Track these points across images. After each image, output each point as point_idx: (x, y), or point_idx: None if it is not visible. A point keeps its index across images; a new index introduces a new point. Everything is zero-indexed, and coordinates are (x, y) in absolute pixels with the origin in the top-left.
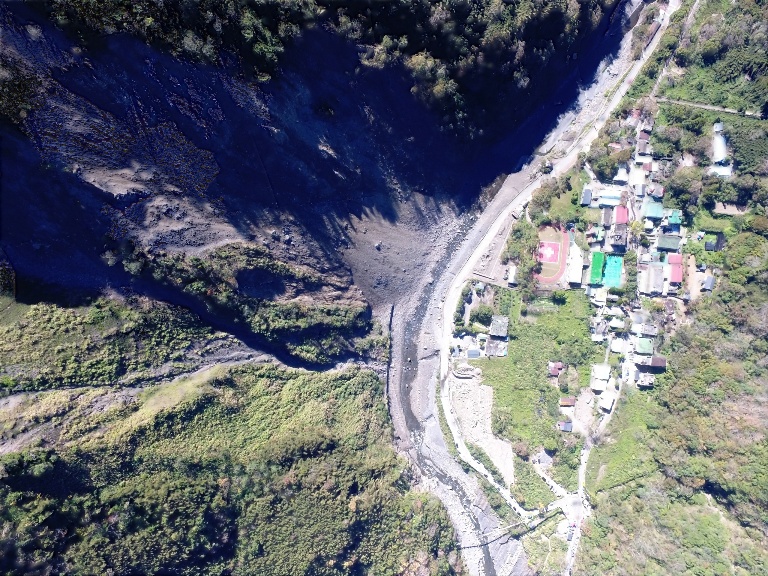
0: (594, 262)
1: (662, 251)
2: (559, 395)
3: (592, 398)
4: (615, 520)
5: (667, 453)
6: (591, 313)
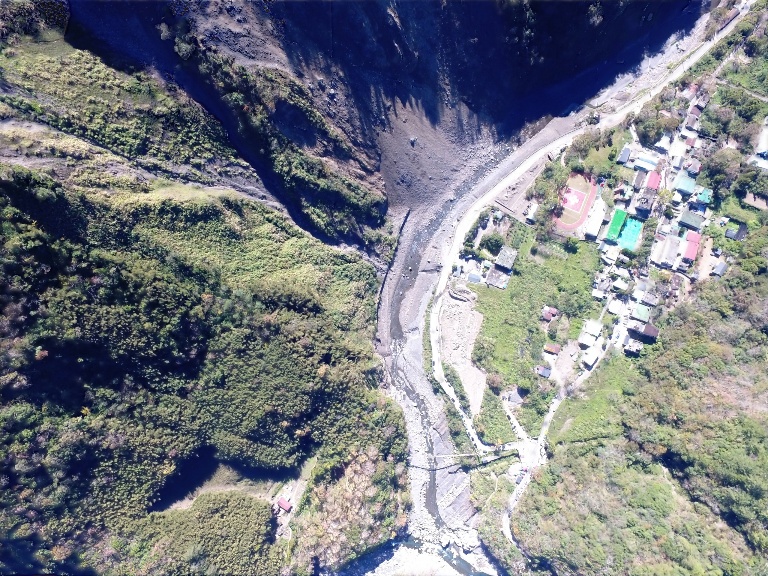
0: (615, 218)
1: (683, 226)
2: (546, 340)
3: (577, 352)
4: (568, 471)
5: (636, 417)
6: (598, 269)
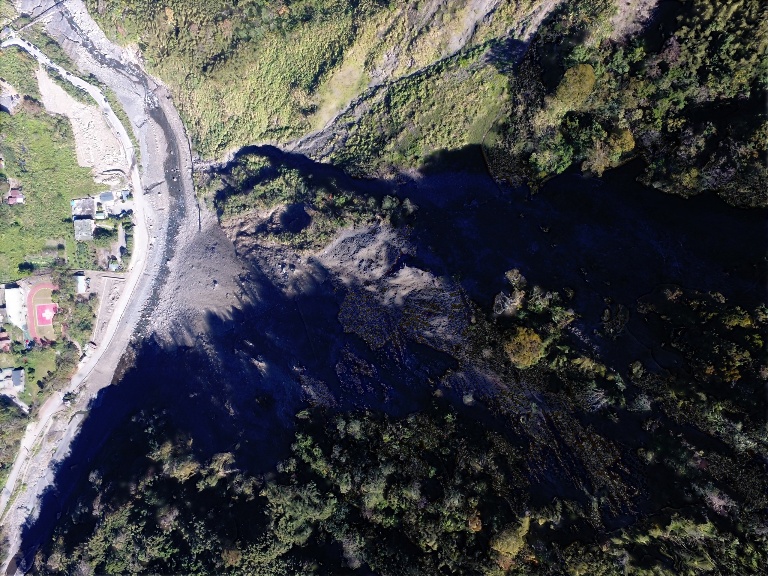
0: None
1: None
2: (5, 170)
3: None
4: None
5: None
6: None
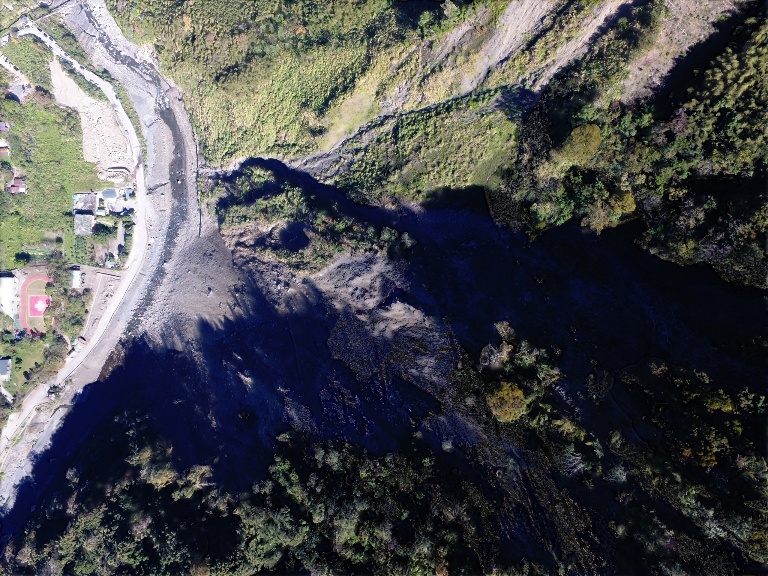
0: None
1: None
2: (11, 159)
3: None
4: None
5: None
6: None
